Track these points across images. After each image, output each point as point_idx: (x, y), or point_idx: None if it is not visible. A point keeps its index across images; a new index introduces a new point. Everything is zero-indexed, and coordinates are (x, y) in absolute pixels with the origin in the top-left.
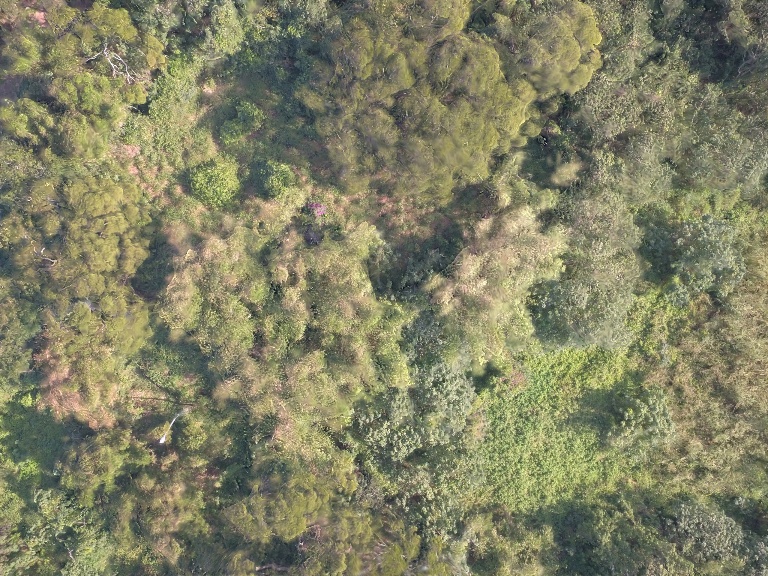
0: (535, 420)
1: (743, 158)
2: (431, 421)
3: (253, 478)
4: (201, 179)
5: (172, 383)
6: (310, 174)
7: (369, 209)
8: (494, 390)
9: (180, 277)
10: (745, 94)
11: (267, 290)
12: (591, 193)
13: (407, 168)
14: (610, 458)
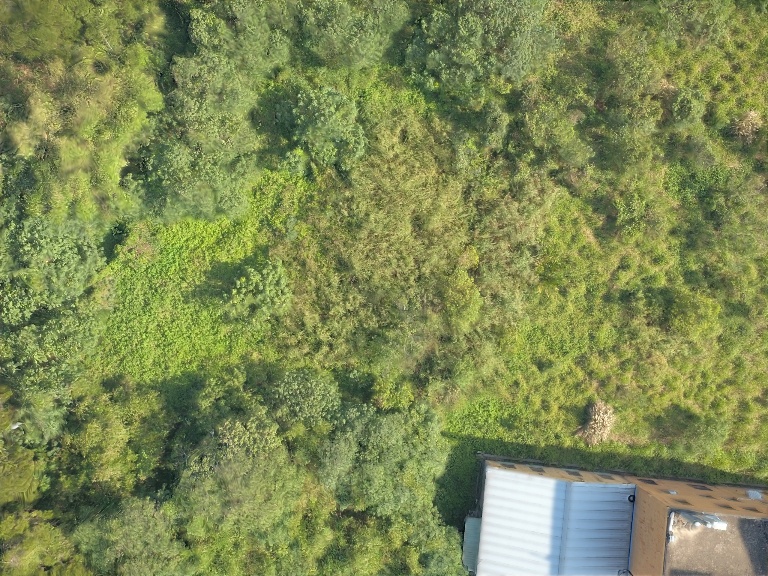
0: (162, 291)
1: (348, 26)
2: (32, 280)
3: None
4: None
5: None
6: None
7: (4, 75)
8: (118, 258)
9: None
10: None
11: None
12: None
13: None
14: (236, 331)
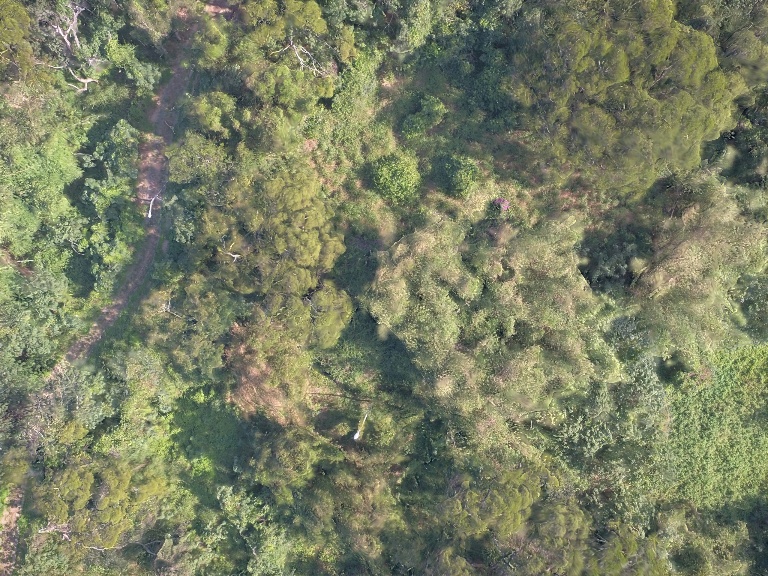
0: (721, 415)
1: None
2: (629, 416)
3: (432, 474)
4: (385, 173)
5: (354, 379)
6: (493, 168)
7: (552, 203)
8: (682, 385)
9: (392, 271)
10: None
11: None
12: None
13: (616, 162)
14: None
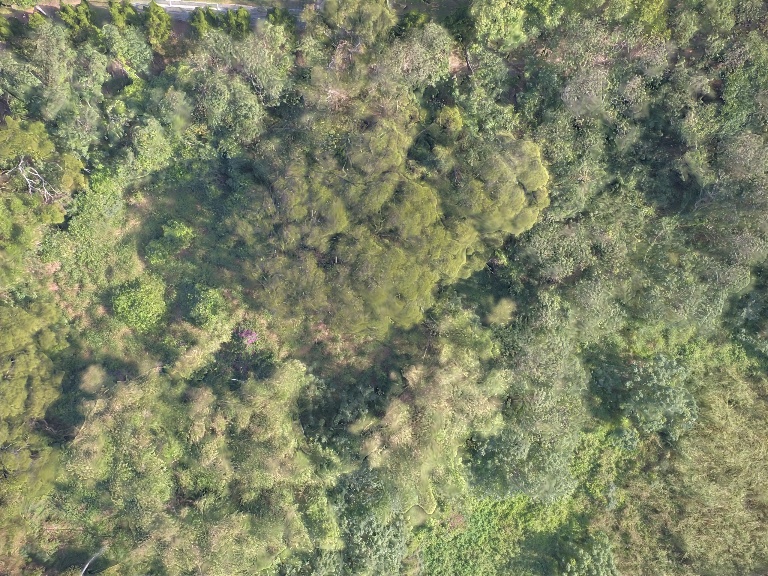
0: (475, 563)
1: (696, 303)
2: (361, 574)
3: None
4: (123, 302)
5: (89, 518)
6: (241, 298)
7: (304, 336)
8: (431, 533)
9: (88, 429)
10: (702, 227)
11: (184, 441)
12: (536, 336)
13: (338, 312)
14: None
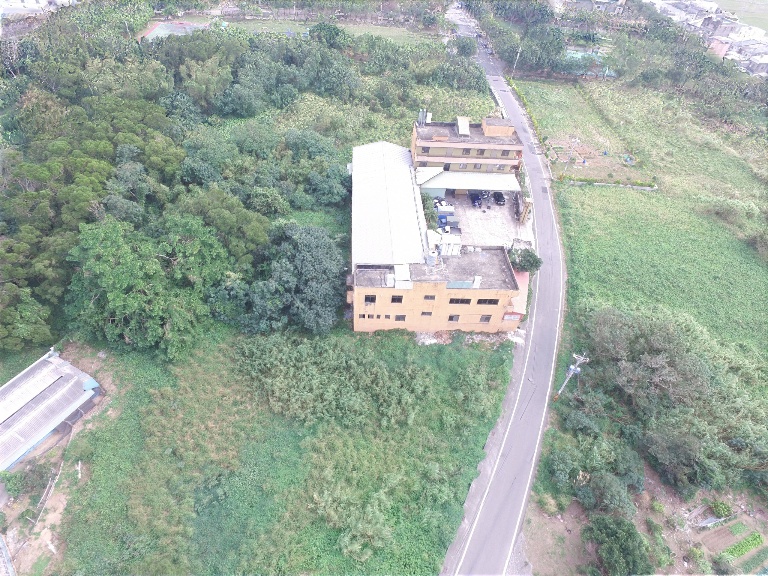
0: None
1: None
2: None
3: None
4: None
5: None
6: None
7: None
8: (208, 119)
9: (92, 64)
10: None
11: None
12: None
13: (182, 59)
14: None
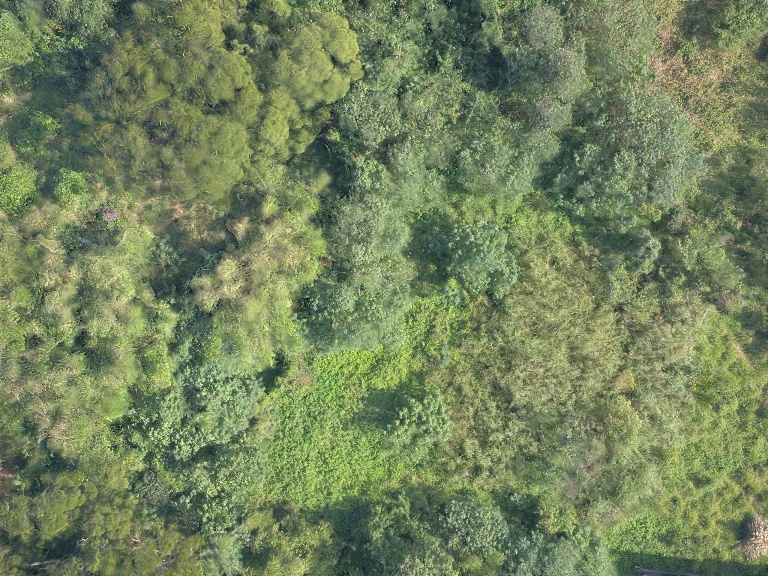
0: (322, 419)
1: (505, 164)
2: (206, 420)
3: (55, 476)
4: None
5: None
6: (104, 181)
7: (161, 215)
8: (279, 390)
9: None
10: (519, 101)
11: (35, 294)
12: None
13: None
14: (395, 456)
